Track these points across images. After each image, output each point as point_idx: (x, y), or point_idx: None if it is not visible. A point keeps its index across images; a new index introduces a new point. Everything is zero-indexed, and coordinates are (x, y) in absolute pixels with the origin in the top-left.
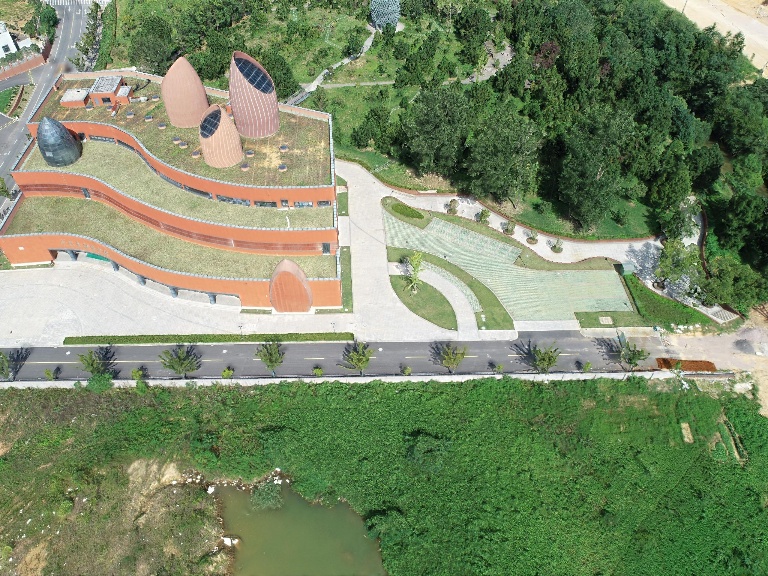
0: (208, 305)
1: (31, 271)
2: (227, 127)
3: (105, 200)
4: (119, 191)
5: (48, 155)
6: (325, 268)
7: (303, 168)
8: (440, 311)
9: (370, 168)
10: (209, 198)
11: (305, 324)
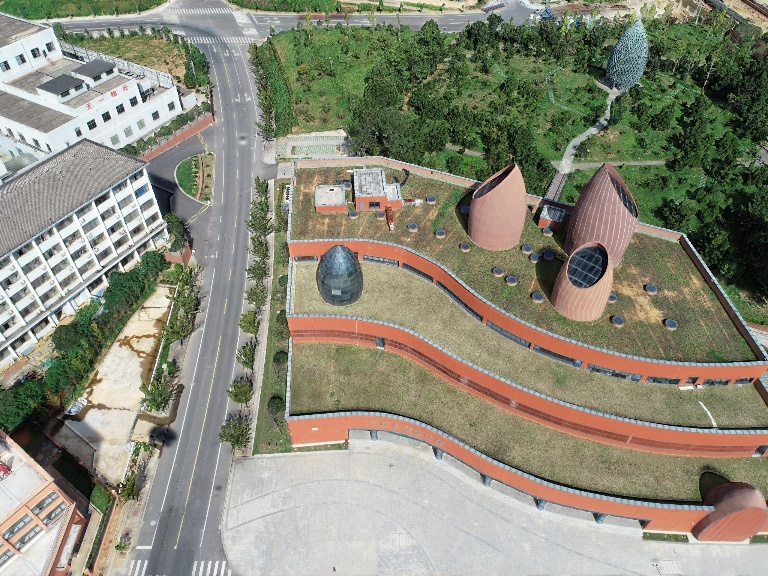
0: (593, 524)
1: (320, 455)
2: (611, 273)
3: (409, 354)
4: (452, 355)
5: (334, 293)
6: (767, 481)
7: (697, 324)
8: None
9: None
10: (574, 365)
11: (745, 562)
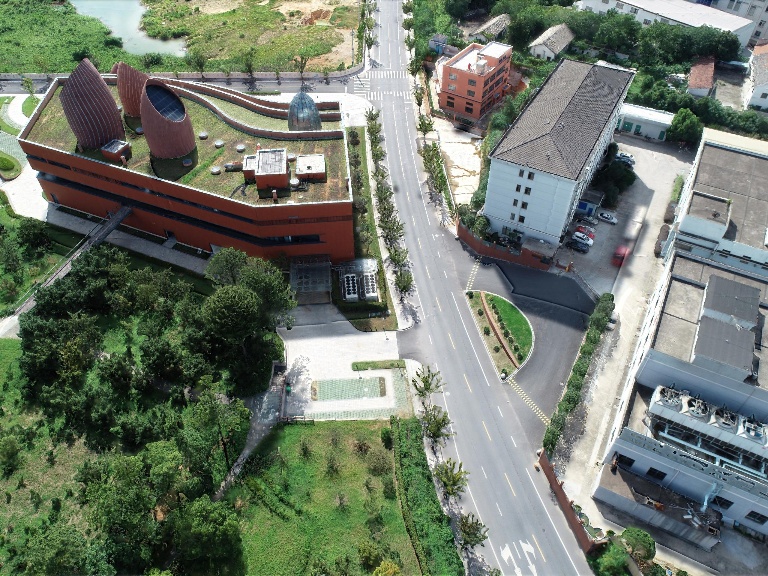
0: None
1: None
2: None
3: None
4: (238, 97)
5: None
6: None
7: None
8: (32, 102)
9: (6, 207)
10: None
11: None
